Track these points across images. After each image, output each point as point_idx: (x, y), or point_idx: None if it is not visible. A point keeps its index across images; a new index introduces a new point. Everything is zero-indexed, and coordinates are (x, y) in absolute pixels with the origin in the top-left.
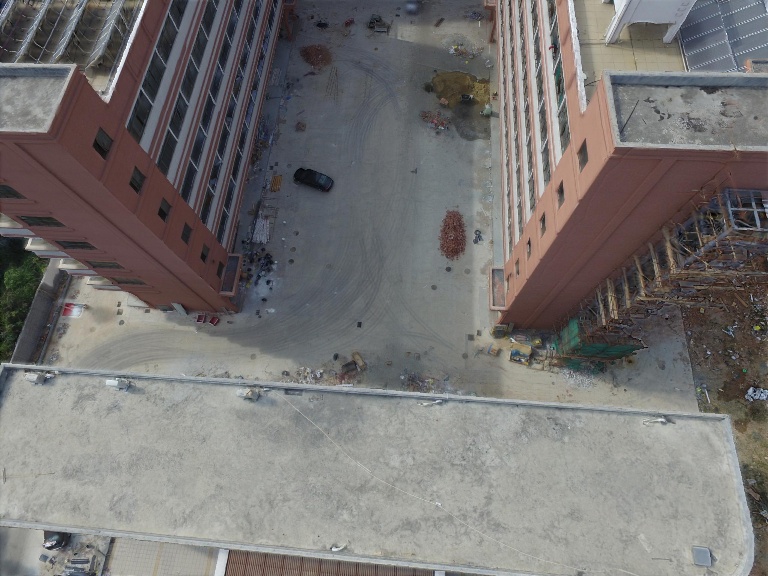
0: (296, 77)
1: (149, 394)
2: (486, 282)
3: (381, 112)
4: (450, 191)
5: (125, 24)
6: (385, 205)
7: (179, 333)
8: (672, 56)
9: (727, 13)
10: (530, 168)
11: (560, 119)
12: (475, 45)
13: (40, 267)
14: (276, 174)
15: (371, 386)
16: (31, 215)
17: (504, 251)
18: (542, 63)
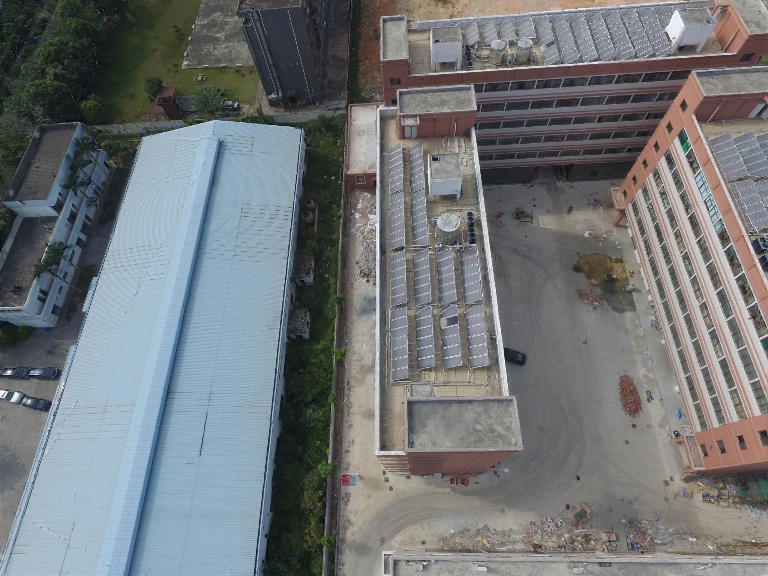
0: None
1: (502, 573)
2: (666, 435)
3: (545, 292)
4: (617, 358)
5: None
6: (570, 373)
7: (439, 495)
8: None
9: None
10: (728, 381)
11: None
12: (603, 229)
13: (323, 449)
14: None
15: (601, 530)
16: (429, 461)
17: (691, 421)
18: (738, 321)
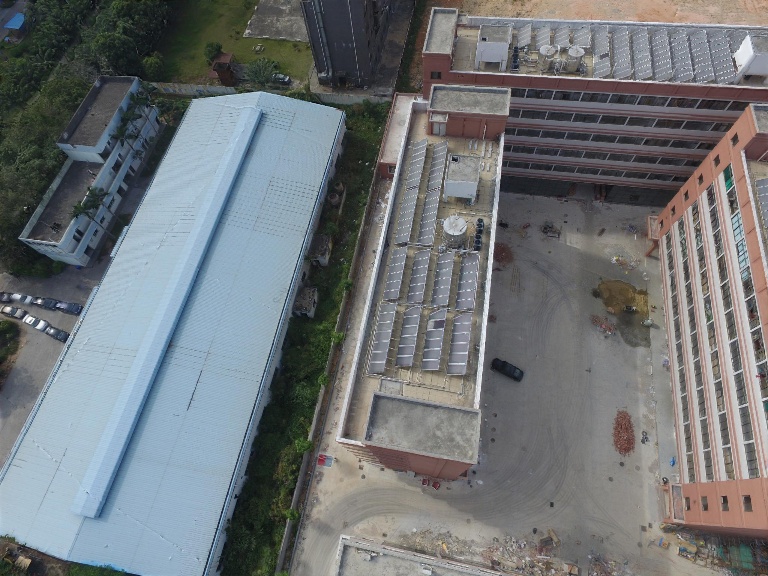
0: None
1: None
2: (654, 480)
3: (557, 312)
4: (619, 392)
5: None
6: (566, 399)
7: (409, 492)
8: None
9: None
10: (724, 437)
11: None
12: (633, 257)
13: (305, 426)
14: None
15: (565, 561)
16: None
17: (681, 470)
18: (745, 377)
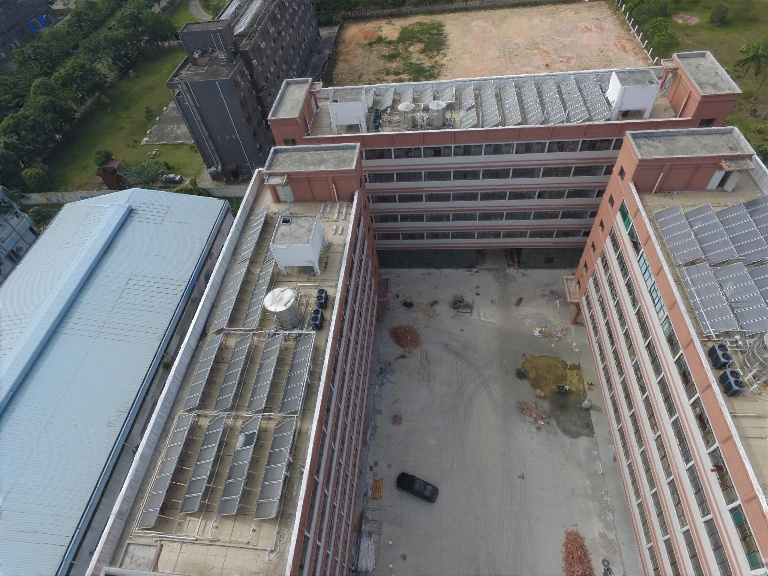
0: (388, 361)
1: None
2: None
3: (476, 402)
4: (564, 504)
5: None
6: (496, 521)
7: None
8: None
9: None
10: (696, 569)
11: None
12: (558, 326)
13: None
14: (376, 477)
15: None
16: None
17: None
18: (699, 473)
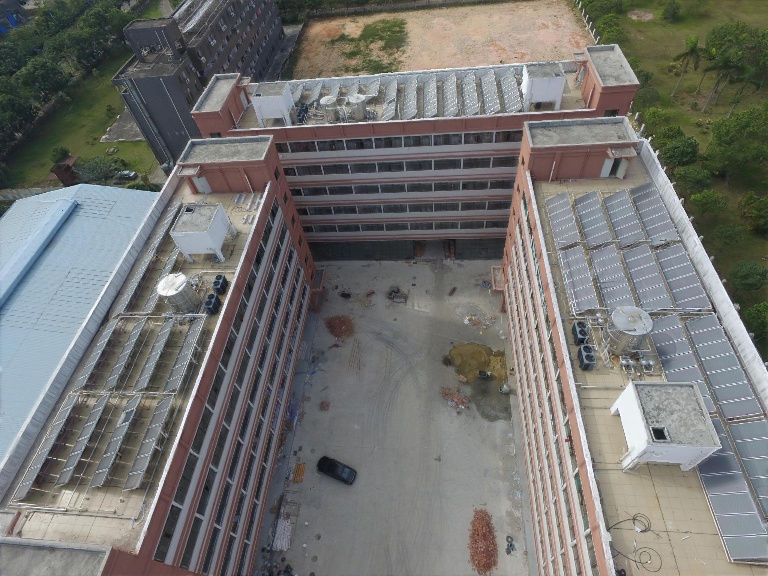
0: (321, 350)
1: None
2: None
3: (402, 388)
4: (476, 484)
5: (165, 437)
6: (410, 502)
7: None
8: (693, 490)
9: (739, 440)
10: (560, 537)
11: (588, 543)
12: (487, 314)
13: None
14: (299, 461)
15: None
16: None
17: None
18: (559, 444)
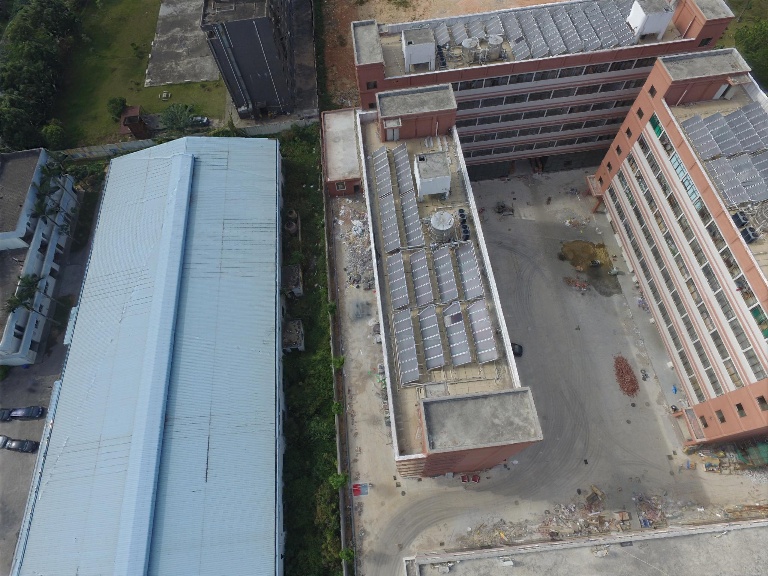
0: None
1: (528, 565)
2: (664, 411)
3: (534, 283)
4: (610, 341)
5: None
6: (567, 360)
7: (452, 494)
8: None
9: None
10: (721, 352)
11: None
12: (582, 216)
13: (331, 461)
14: None
15: (614, 510)
16: None
17: (687, 394)
18: (727, 294)
